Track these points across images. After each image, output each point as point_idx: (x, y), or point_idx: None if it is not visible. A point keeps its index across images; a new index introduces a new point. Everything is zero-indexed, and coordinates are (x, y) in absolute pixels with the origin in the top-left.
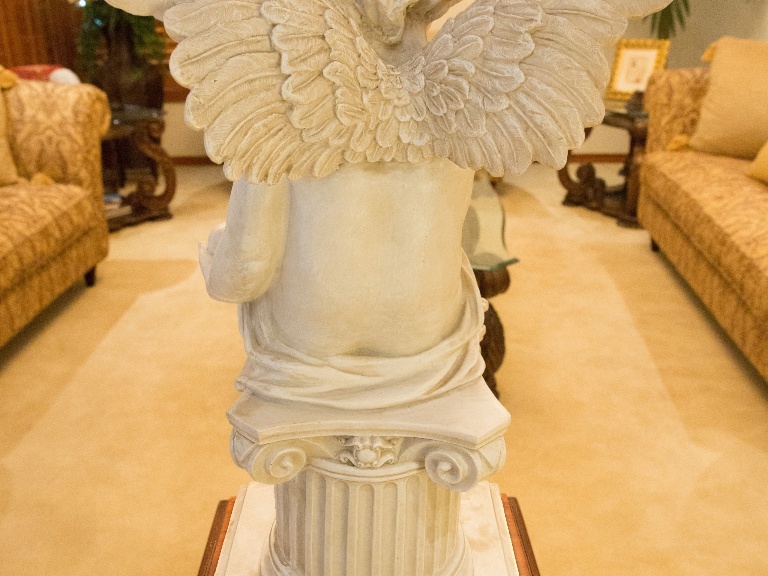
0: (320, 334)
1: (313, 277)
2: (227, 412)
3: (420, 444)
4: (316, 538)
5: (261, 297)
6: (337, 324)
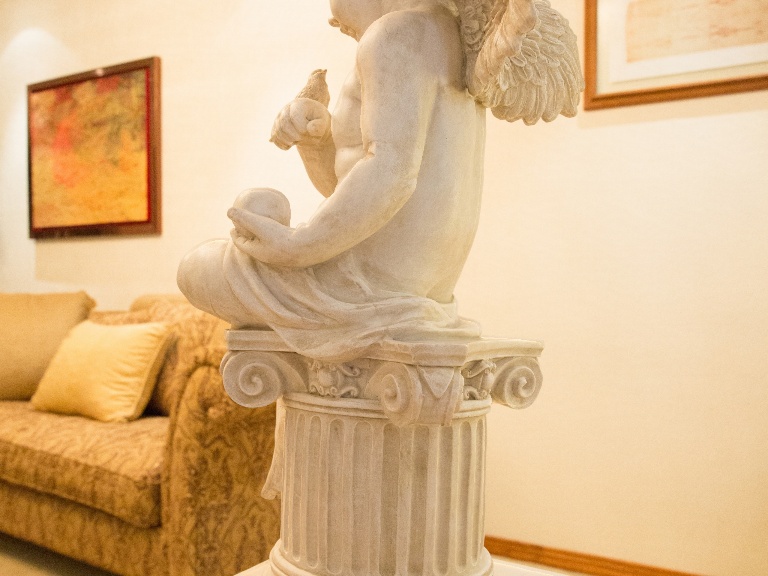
0: (433, 268)
1: (452, 197)
2: (414, 346)
3: (502, 367)
4: (437, 512)
5: (349, 249)
6: (448, 254)
